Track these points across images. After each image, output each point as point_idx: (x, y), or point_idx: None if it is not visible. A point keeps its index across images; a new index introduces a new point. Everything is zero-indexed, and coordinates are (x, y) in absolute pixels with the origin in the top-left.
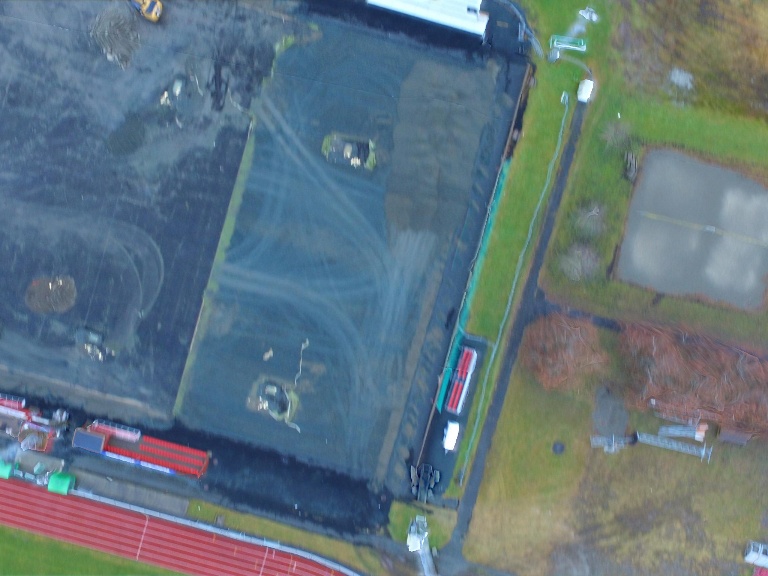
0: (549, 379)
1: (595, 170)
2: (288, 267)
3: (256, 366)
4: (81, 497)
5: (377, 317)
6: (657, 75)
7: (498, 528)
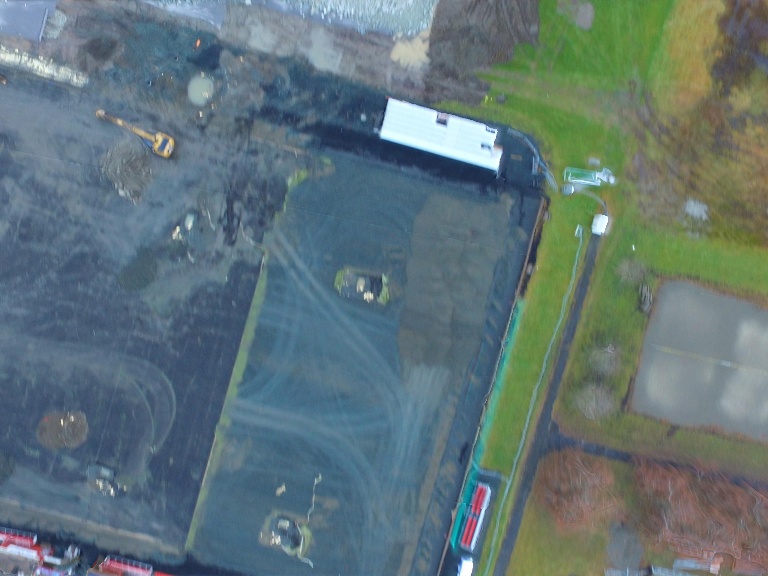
0: (564, 517)
1: (609, 302)
2: (301, 402)
3: (269, 501)
4: None
5: (390, 452)
6: (672, 206)
7: None
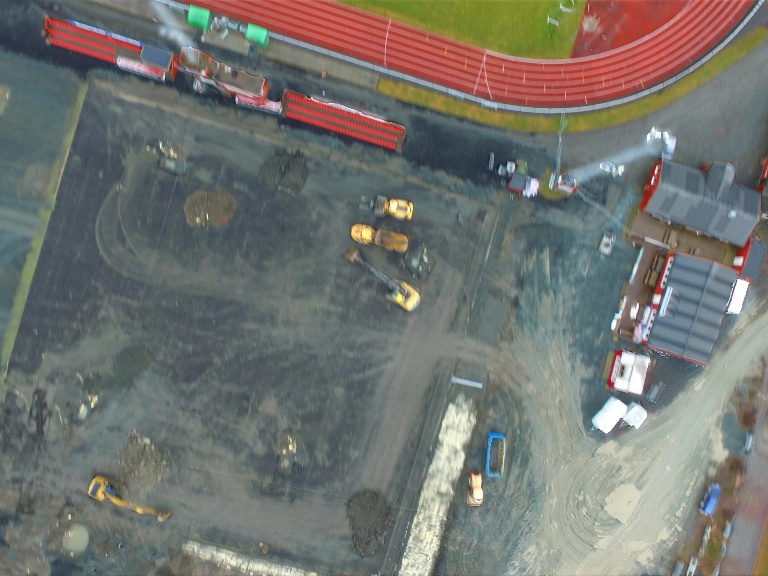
0: None
1: None
2: None
3: (0, 131)
4: (181, 2)
5: None
6: None
7: None
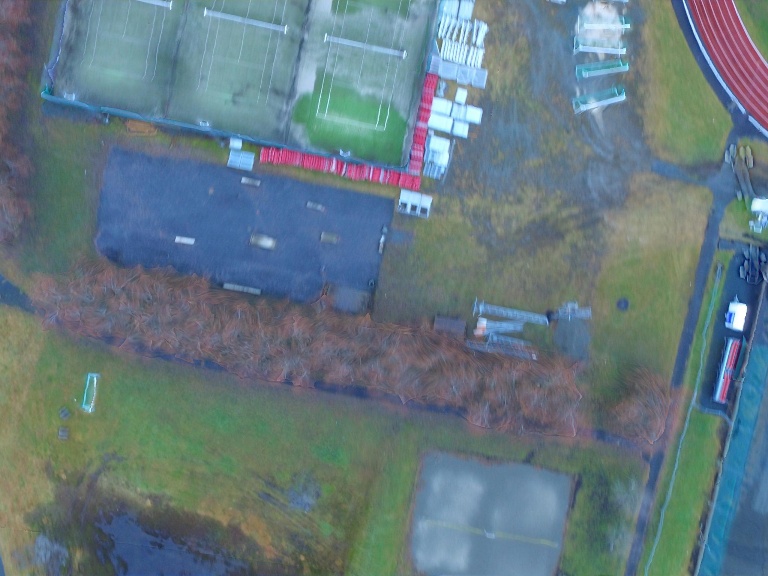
0: (651, 379)
1: None
2: None
3: None
4: None
5: None
6: None
7: (680, 222)
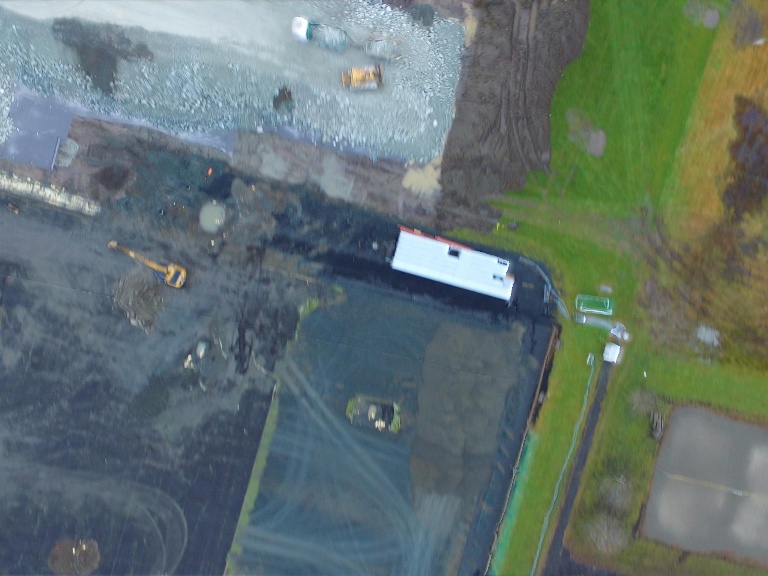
0: None
1: (621, 429)
2: (312, 530)
3: None
4: None
5: None
6: (683, 333)
7: None
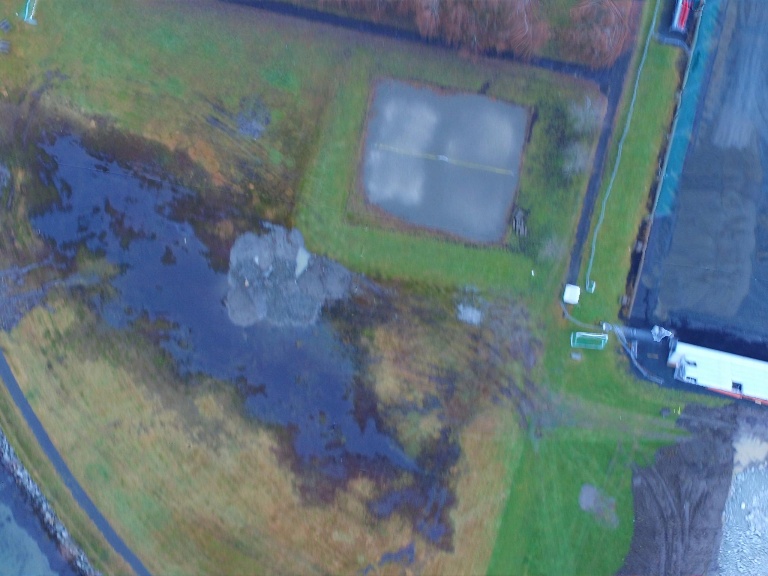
0: None
1: (555, 217)
2: None
3: None
4: None
5: (766, 61)
6: (496, 316)
7: None
